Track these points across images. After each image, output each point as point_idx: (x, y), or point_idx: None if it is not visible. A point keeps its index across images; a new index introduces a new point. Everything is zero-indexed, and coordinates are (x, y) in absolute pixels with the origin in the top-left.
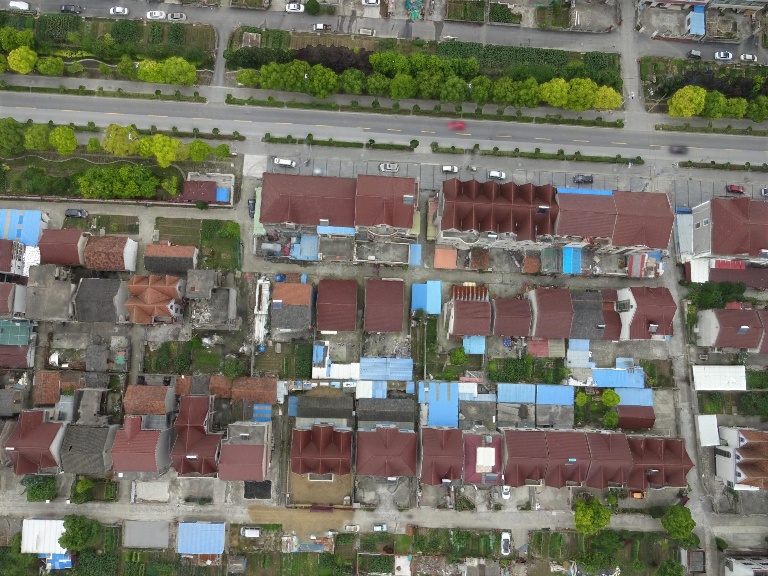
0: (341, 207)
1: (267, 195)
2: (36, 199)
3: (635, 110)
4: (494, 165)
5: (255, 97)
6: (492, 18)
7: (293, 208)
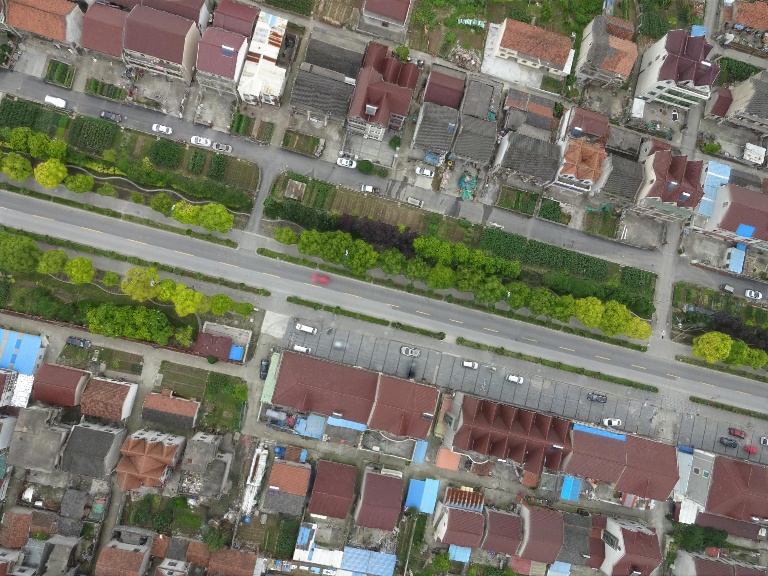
0: (358, 405)
1: (284, 377)
2: (38, 319)
3: (660, 336)
4: (514, 367)
5: (288, 252)
6: (542, 214)
7: (309, 397)
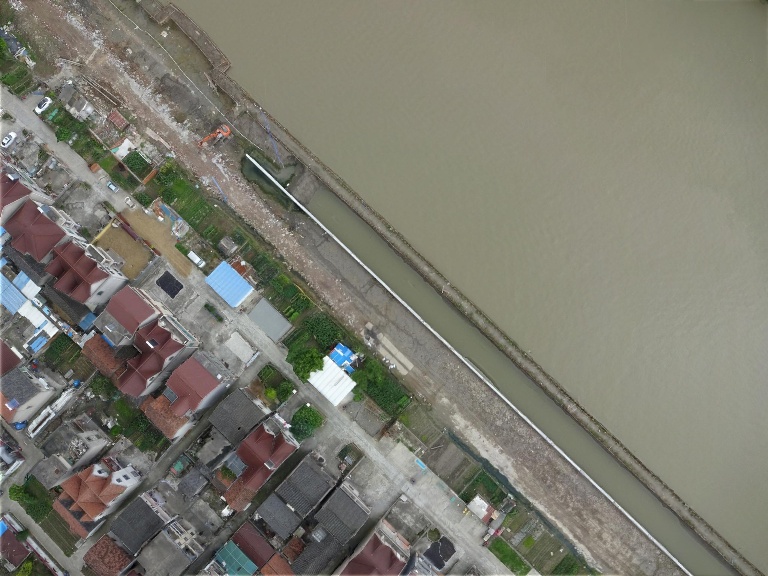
0: None
1: None
2: None
3: None
4: None
5: None
6: None
7: None
